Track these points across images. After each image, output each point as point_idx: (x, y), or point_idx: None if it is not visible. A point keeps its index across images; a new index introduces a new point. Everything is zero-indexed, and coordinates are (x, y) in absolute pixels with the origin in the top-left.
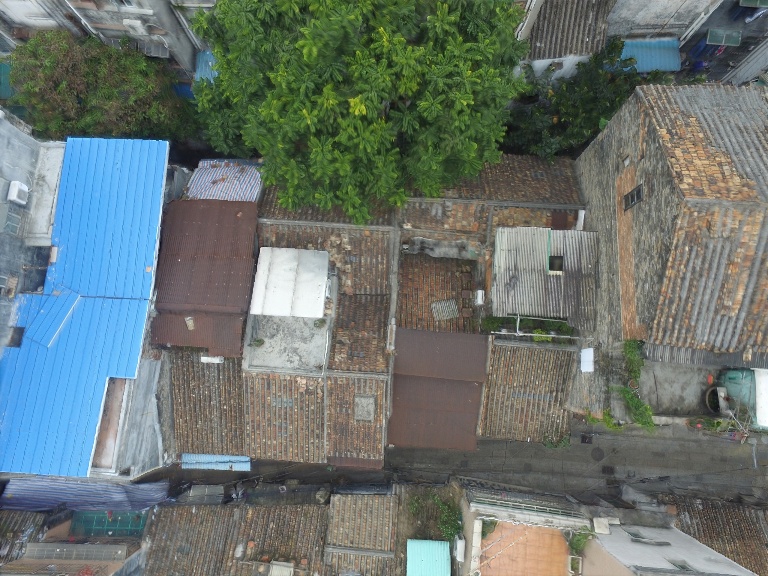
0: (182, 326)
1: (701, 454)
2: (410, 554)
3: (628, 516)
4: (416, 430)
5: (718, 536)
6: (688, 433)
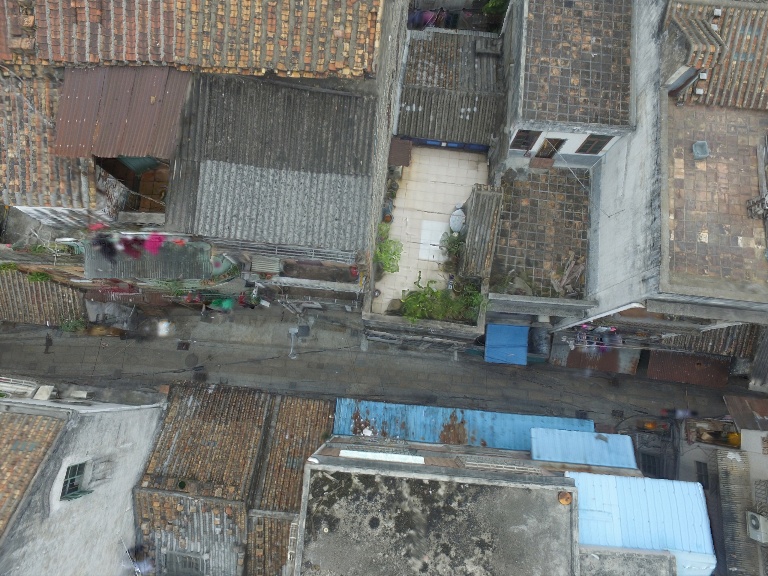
0: None
1: (297, 361)
2: None
3: (116, 395)
4: None
5: (212, 418)
6: (287, 340)
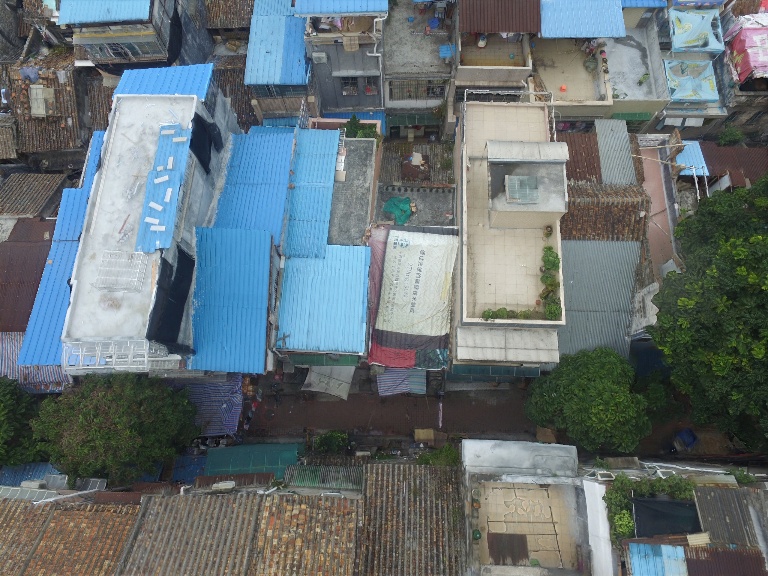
0: None
1: None
2: None
3: None
4: None
5: None
6: None
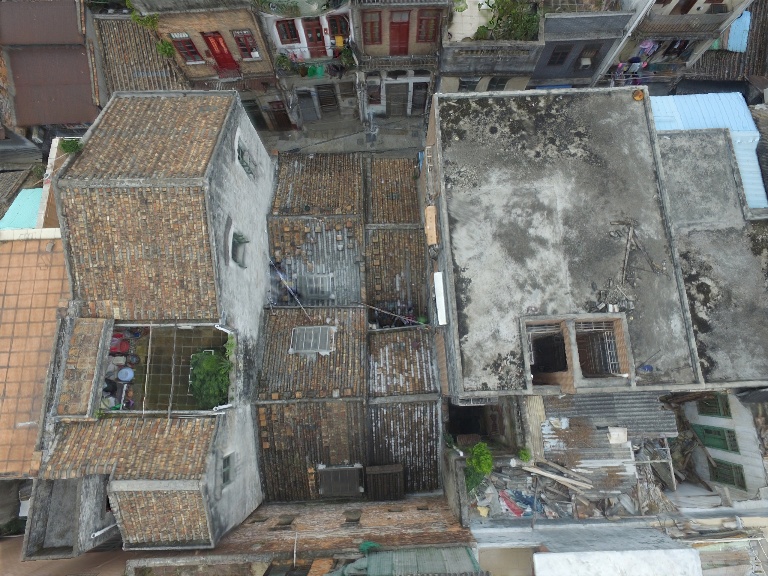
0: None
1: None
2: (19, 196)
3: None
4: (41, 108)
5: (318, 172)
6: (357, 147)
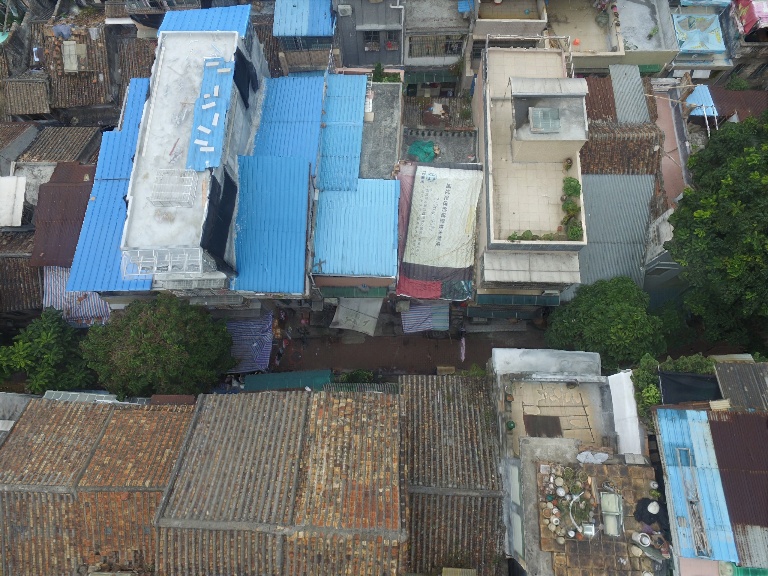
0: (93, 176)
1: None
2: None
3: None
4: None
5: None
6: None
